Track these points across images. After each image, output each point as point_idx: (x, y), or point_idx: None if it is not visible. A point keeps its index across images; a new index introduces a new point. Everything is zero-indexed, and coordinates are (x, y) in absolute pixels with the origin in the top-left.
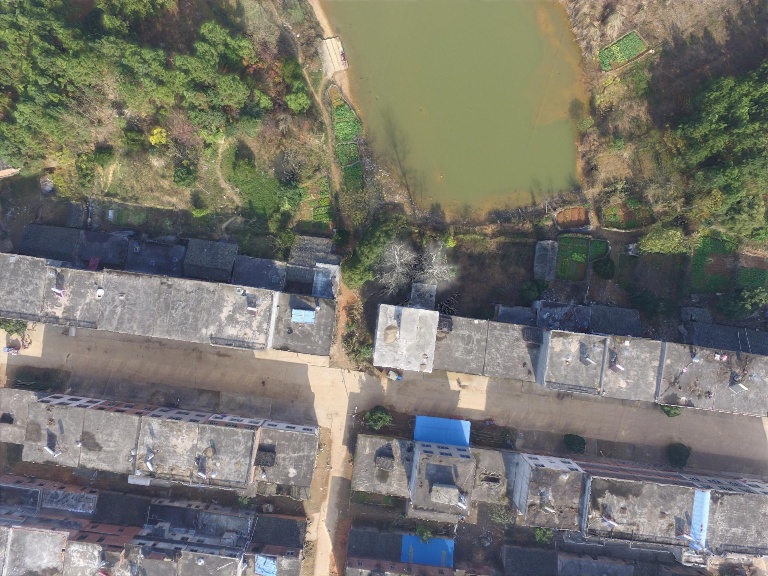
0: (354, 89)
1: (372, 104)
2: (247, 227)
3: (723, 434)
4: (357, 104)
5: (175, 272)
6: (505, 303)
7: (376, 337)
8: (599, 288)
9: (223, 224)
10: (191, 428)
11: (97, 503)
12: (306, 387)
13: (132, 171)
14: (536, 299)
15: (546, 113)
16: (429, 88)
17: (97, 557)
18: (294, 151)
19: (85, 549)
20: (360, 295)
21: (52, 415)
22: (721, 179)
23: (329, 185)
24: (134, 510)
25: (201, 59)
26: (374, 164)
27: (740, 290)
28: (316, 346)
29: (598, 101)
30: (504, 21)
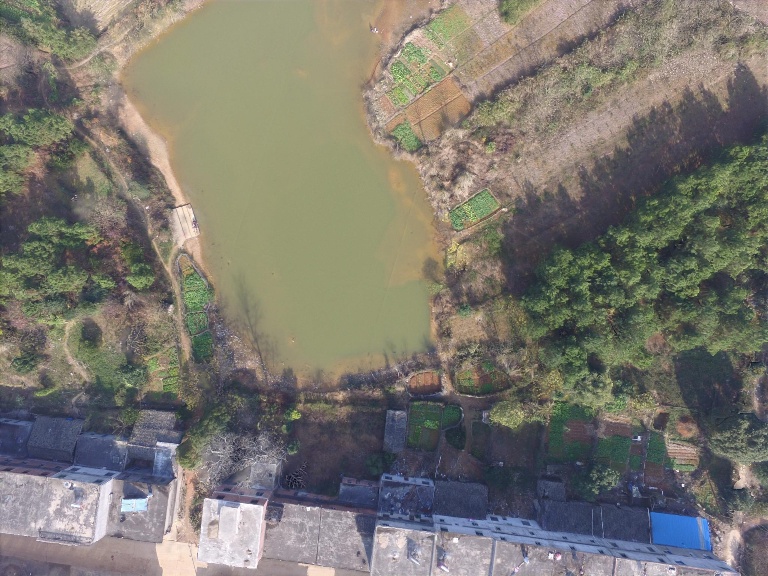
0: (206, 255)
1: (224, 269)
2: (93, 403)
3: None
4: (209, 270)
5: (20, 453)
6: (353, 476)
7: (200, 532)
8: (451, 459)
9: (72, 398)
10: None
11: None
12: (154, 562)
13: None
14: (381, 474)
15: (399, 273)
16: (280, 251)
17: None
18: (141, 324)
19: None
20: (198, 476)
21: None
22: (558, 360)
23: (178, 355)
24: None
25: (28, 258)
26: (226, 330)
27: (590, 469)
28: (149, 533)
29: (448, 263)
30: (355, 181)
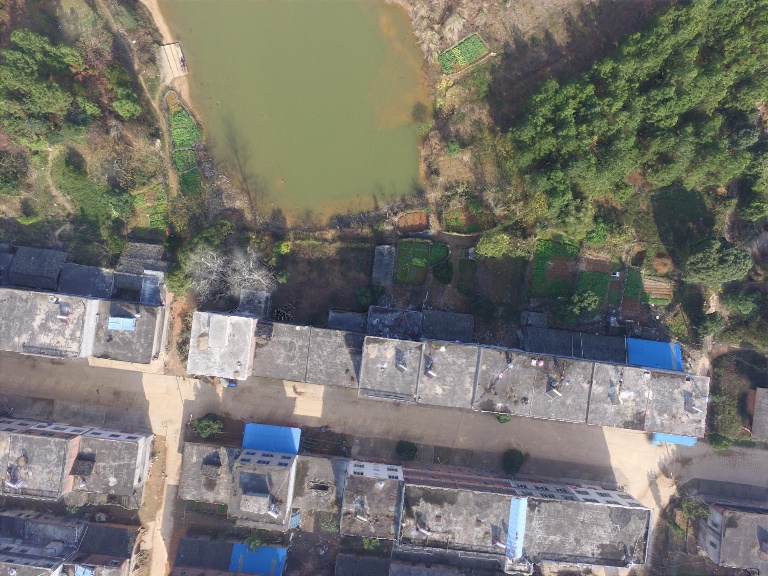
0: (194, 95)
1: (213, 110)
2: (78, 234)
3: (562, 440)
4: (197, 110)
5: (1, 280)
6: (341, 309)
7: None
8: (438, 293)
9: (56, 231)
10: (3, 437)
11: None
12: (141, 395)
13: None
14: (370, 305)
15: (389, 117)
16: (270, 93)
17: None
18: (128, 158)
19: None
20: (186, 302)
21: None
22: (544, 182)
23: (165, 191)
24: None
25: (10, 67)
26: (214, 170)
27: (572, 294)
28: (137, 354)
29: (438, 104)
30: (346, 25)
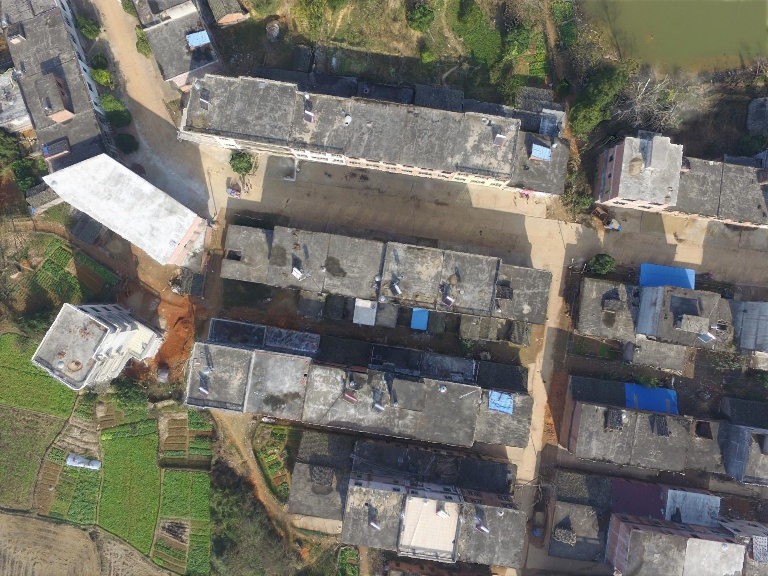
0: None
1: None
2: (470, 75)
3: None
4: None
5: None
6: None
7: (621, 169)
8: None
9: (444, 74)
10: (436, 255)
11: (319, 344)
12: (523, 237)
13: (363, 14)
14: (756, 153)
15: None
16: None
17: (340, 382)
18: (514, 4)
19: (328, 374)
20: (588, 140)
21: (297, 240)
22: None
23: (546, 40)
24: (356, 351)
25: None
26: (585, 24)
27: None
28: (551, 184)
29: None
30: None
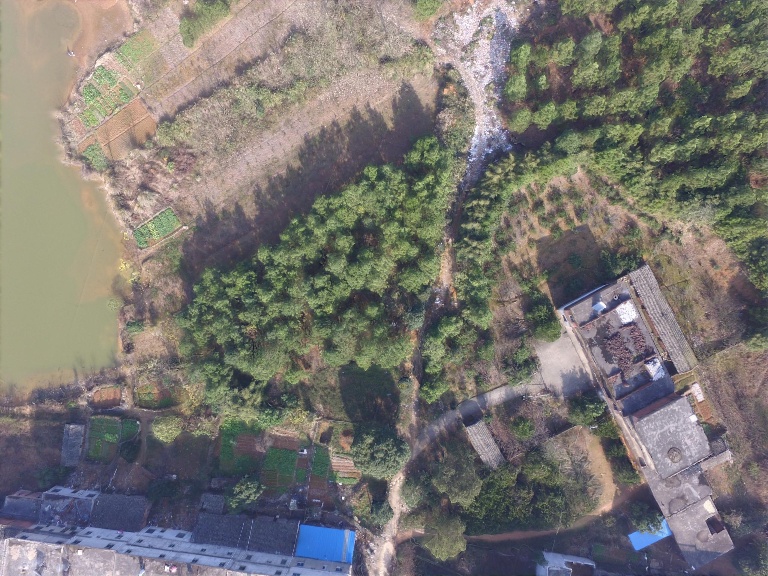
0: None
1: None
2: None
3: None
4: None
5: None
6: (29, 488)
7: None
8: (124, 471)
9: None
10: None
11: None
12: None
13: None
14: (51, 487)
15: (90, 290)
16: None
17: None
18: None
19: None
20: None
21: None
22: None
23: None
24: None
25: None
26: None
27: None
28: None
29: (129, 280)
30: (51, 201)
